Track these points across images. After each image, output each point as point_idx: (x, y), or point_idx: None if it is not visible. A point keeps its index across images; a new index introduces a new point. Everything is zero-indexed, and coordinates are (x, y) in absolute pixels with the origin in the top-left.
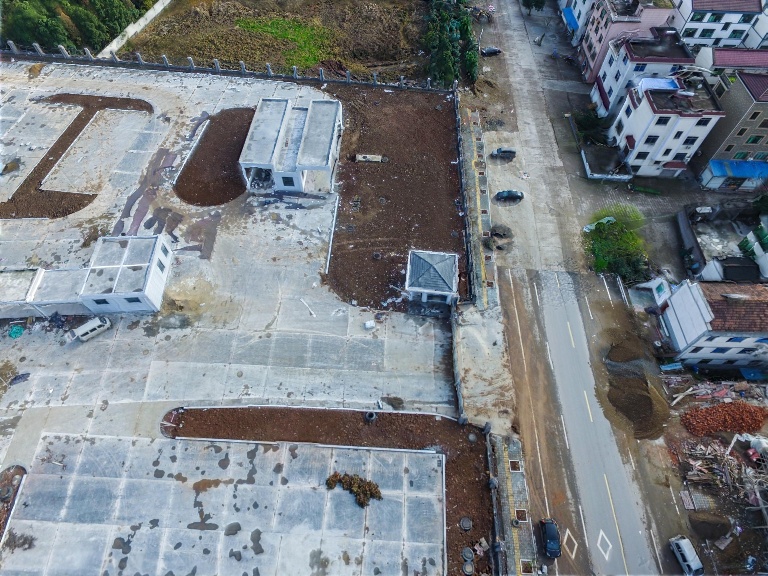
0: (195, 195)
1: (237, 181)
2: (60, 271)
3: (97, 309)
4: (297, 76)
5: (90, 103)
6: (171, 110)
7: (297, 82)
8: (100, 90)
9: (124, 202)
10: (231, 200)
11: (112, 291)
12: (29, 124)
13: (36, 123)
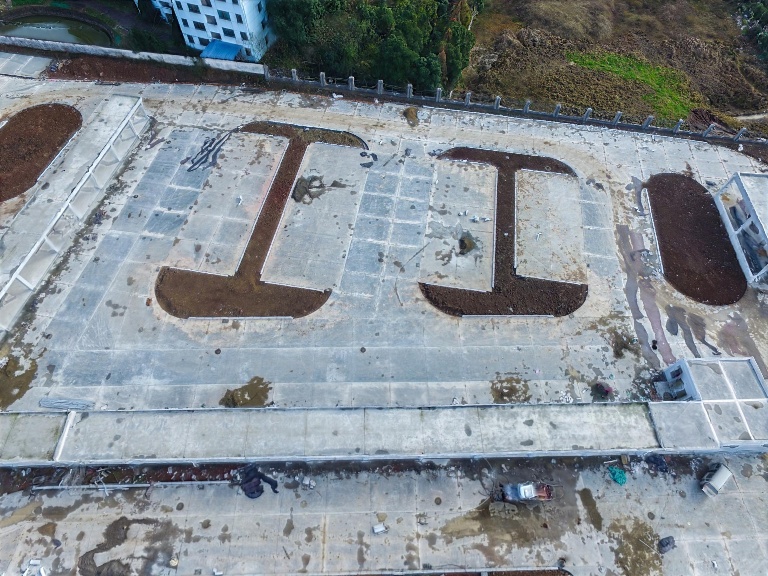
0: (697, 290)
1: (732, 272)
2: (668, 405)
3: (705, 450)
4: (707, 134)
5: (501, 161)
6: (596, 174)
7: (708, 141)
8: (499, 144)
9: (624, 296)
10: (739, 297)
11: (751, 437)
12: (450, 186)
13: (457, 185)
